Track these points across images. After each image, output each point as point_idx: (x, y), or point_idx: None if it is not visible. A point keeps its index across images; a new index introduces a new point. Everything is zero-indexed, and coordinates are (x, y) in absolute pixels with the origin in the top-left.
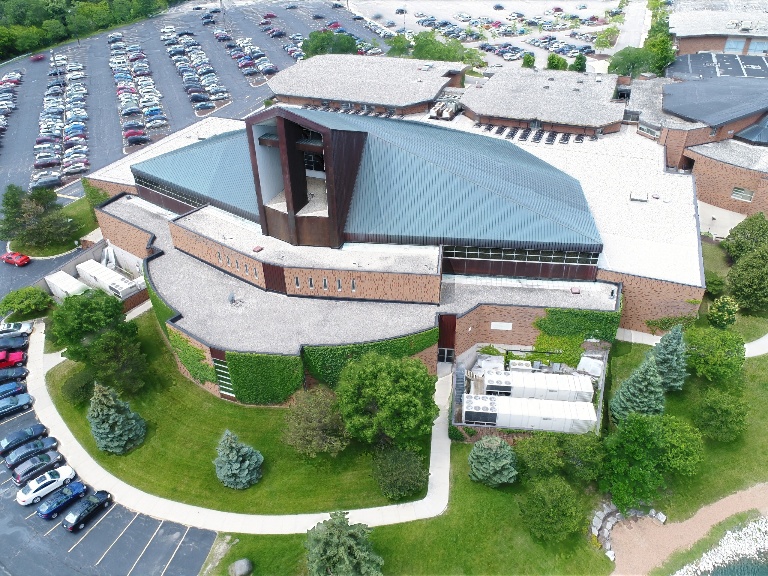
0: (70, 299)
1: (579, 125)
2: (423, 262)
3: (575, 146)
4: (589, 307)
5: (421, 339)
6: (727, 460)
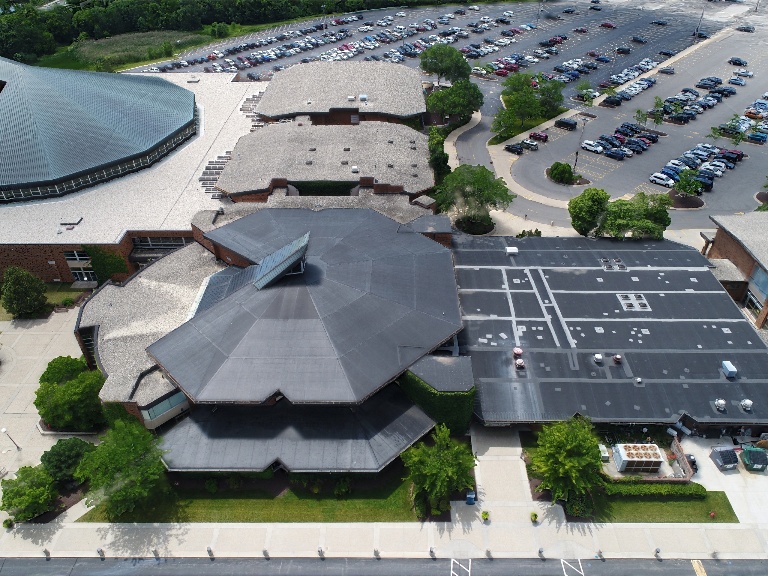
0: None
1: None
2: None
3: (196, 191)
4: None
5: None
6: None
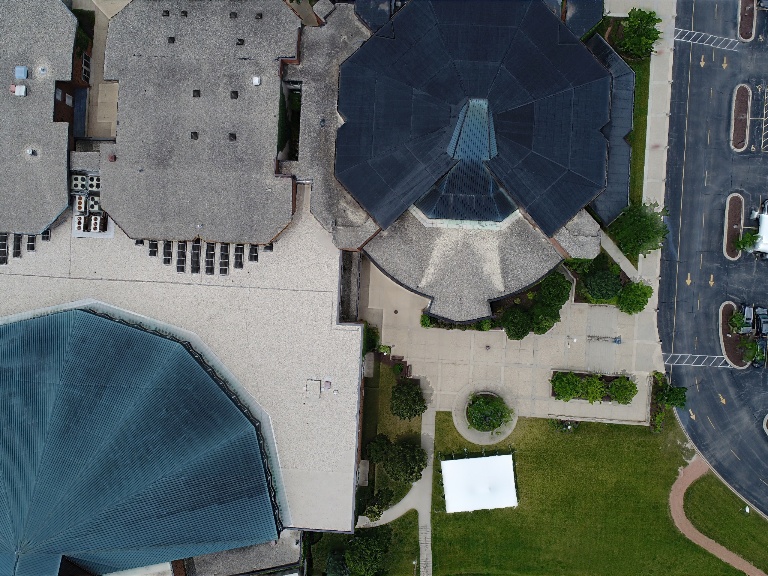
0: None
1: None
2: None
3: (251, 273)
4: (283, 559)
5: None
6: None
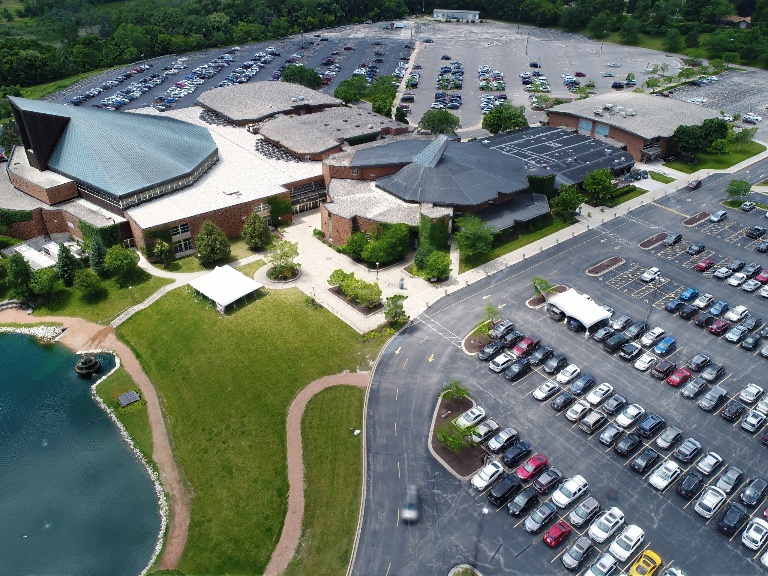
0: None
1: (292, 150)
2: (54, 184)
3: (278, 162)
4: (98, 224)
5: (21, 214)
6: (82, 305)
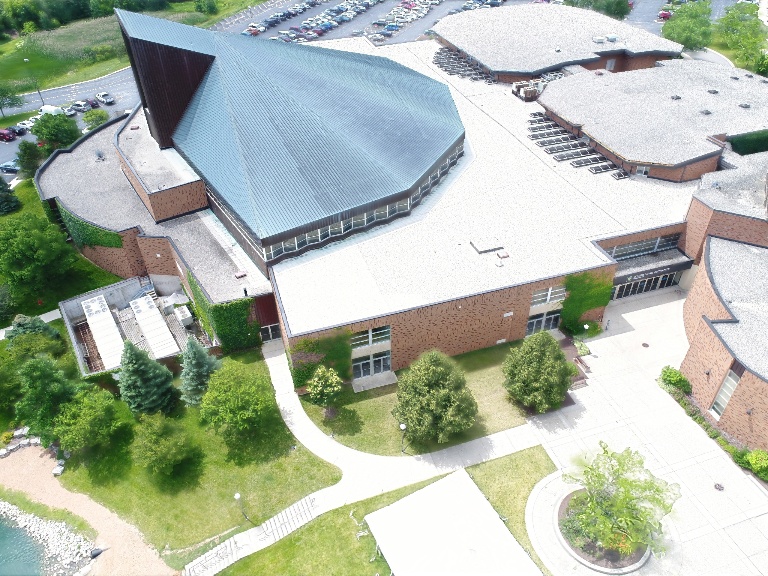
0: (45, 114)
1: (611, 151)
2: (168, 182)
3: (578, 173)
4: (216, 290)
5: (106, 235)
6: (146, 489)
